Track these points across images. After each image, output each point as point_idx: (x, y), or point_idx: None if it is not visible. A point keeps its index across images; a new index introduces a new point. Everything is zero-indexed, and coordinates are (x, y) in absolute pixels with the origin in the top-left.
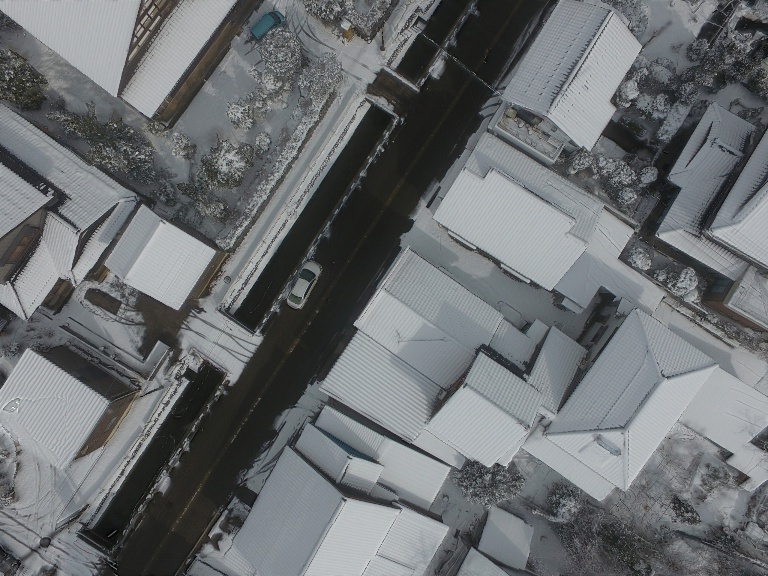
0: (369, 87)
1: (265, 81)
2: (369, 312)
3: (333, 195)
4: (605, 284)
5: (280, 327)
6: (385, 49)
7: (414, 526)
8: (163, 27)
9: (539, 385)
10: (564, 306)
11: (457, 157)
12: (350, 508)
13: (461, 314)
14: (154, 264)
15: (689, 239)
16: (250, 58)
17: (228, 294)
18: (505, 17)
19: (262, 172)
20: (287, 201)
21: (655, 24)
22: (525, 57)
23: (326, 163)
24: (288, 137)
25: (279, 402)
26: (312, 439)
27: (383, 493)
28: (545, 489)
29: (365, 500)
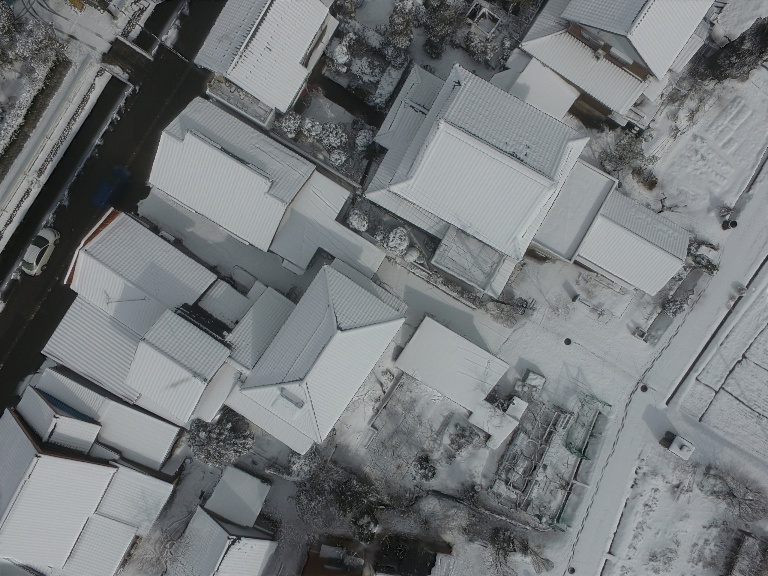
0: (104, 56)
1: None
2: (78, 274)
3: None
4: (322, 245)
5: (21, 294)
6: (118, 19)
7: (134, 485)
8: None
9: (239, 342)
10: (284, 267)
11: None
12: (46, 465)
13: (168, 275)
14: None
15: (394, 199)
16: None
17: None
18: None
19: None
20: (26, 170)
21: None
22: (216, 21)
23: (68, 132)
24: (14, 105)
25: (21, 368)
26: (29, 401)
27: (102, 453)
28: (288, 450)
29: (72, 458)
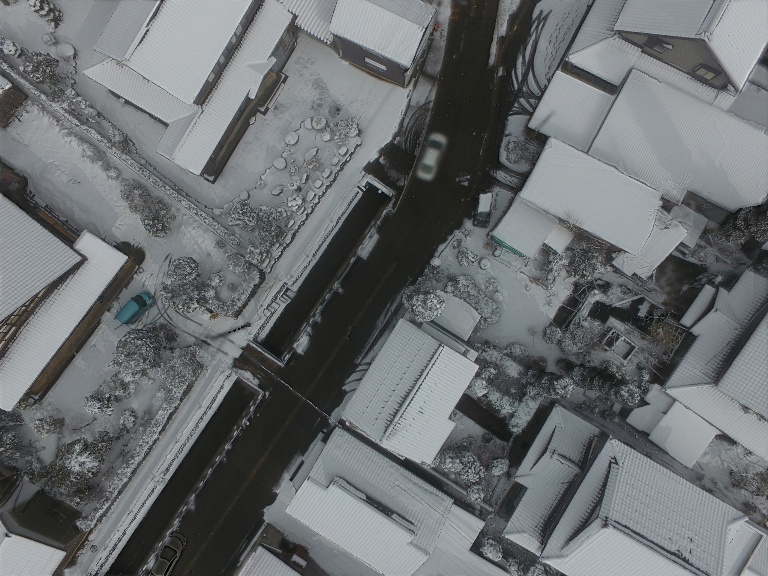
0: (235, 361)
1: (123, 375)
2: None
3: (204, 456)
4: (457, 575)
5: None
6: (251, 325)
7: None
8: (19, 334)
9: None
10: None
11: (320, 431)
12: None
13: None
14: (1, 573)
15: (534, 541)
16: (120, 333)
17: (94, 564)
18: (368, 295)
19: (123, 455)
20: (154, 471)
21: (512, 307)
22: (366, 374)
23: (195, 430)
24: (150, 421)
25: None
26: None
27: None
28: None
29: None
